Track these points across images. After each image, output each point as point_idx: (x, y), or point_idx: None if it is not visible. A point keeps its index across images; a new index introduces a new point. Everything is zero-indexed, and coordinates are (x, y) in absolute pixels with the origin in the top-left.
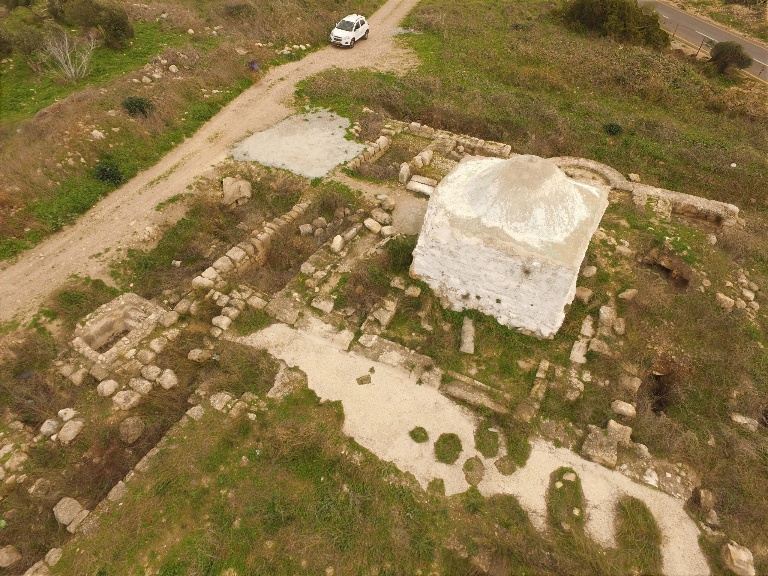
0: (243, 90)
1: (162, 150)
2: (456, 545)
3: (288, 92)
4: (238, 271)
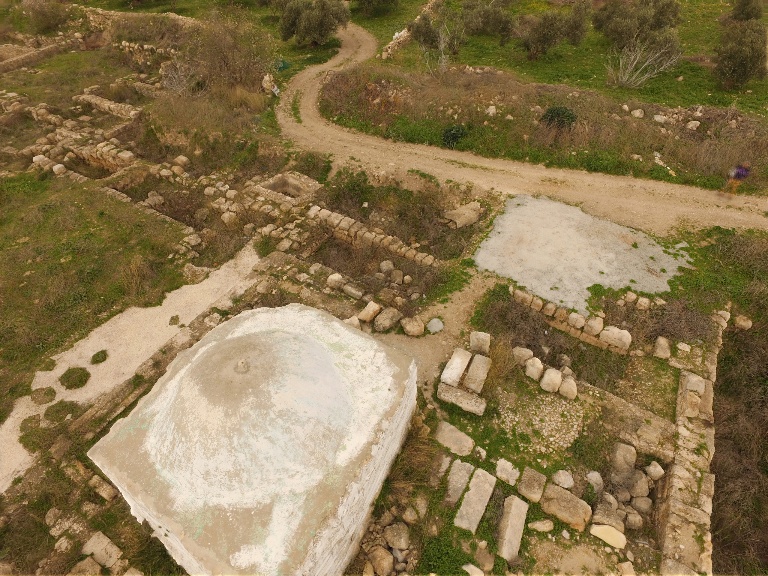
0: (695, 185)
1: (510, 155)
2: None
3: (716, 221)
4: (334, 232)
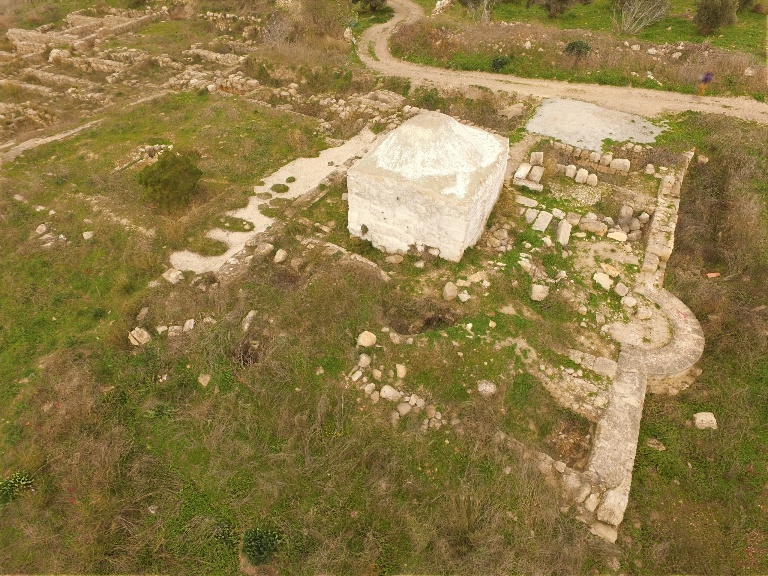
0: (676, 91)
1: (542, 76)
2: (231, 187)
3: (689, 109)
4: None
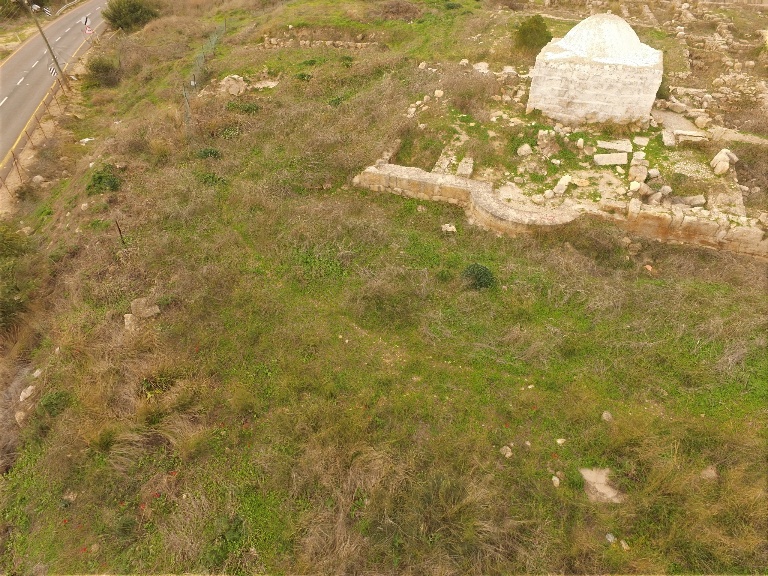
0: None
1: None
2: None
3: None
4: None
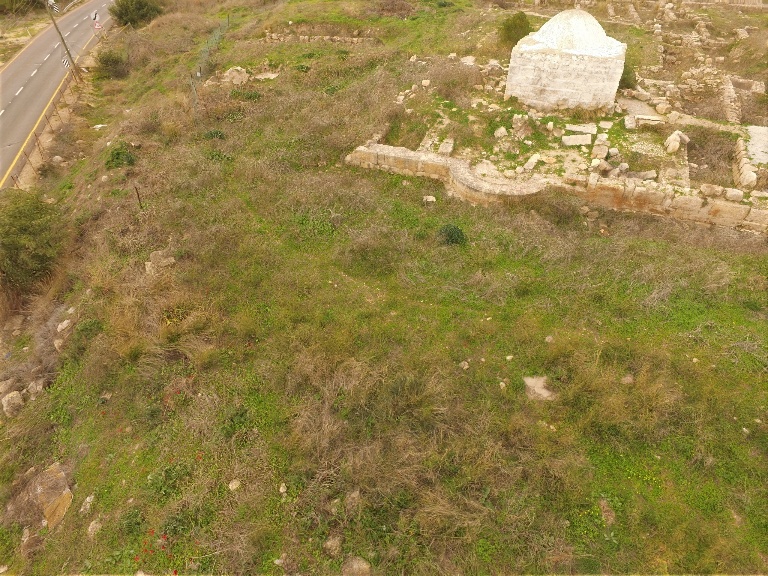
0: None
1: None
2: None
3: None
4: None
